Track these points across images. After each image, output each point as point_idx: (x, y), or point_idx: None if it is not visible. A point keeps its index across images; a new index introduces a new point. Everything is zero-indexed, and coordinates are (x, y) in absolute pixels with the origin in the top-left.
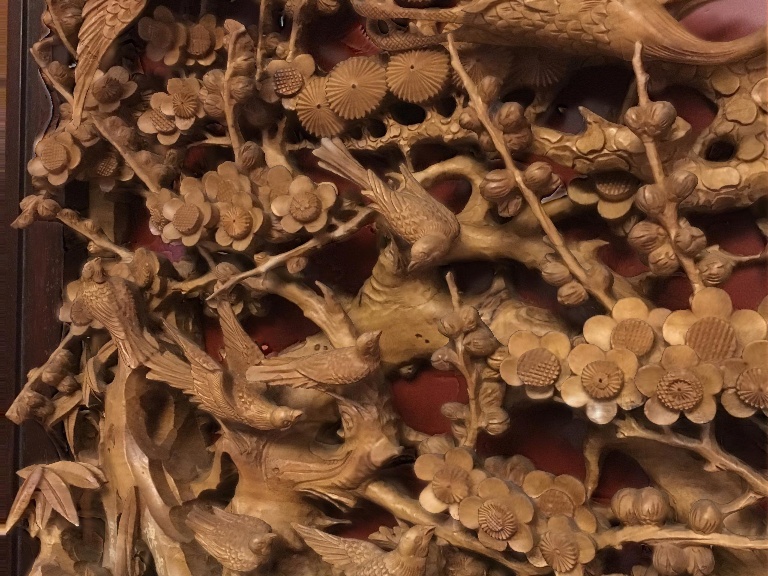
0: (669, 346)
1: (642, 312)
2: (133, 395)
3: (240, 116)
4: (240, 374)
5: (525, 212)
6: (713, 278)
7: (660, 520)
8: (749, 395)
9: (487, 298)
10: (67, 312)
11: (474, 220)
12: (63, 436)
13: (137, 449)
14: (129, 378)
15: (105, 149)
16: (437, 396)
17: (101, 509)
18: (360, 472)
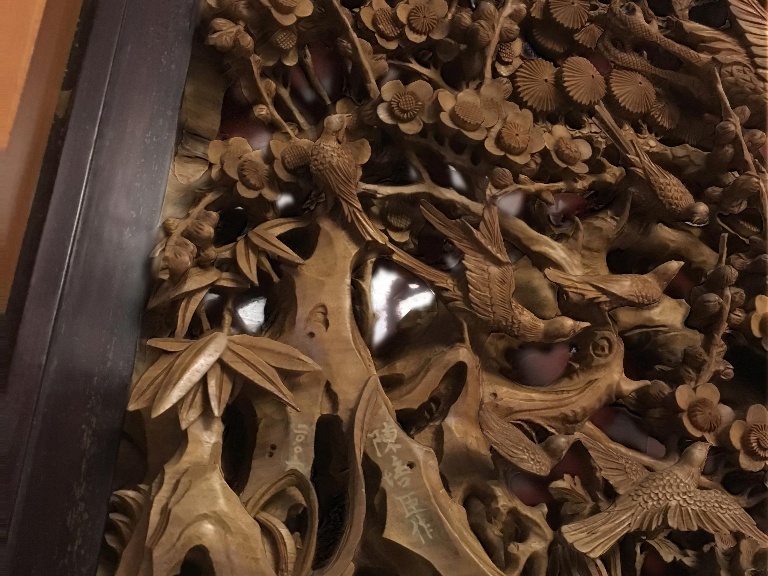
0: None
1: None
2: None
3: (455, 58)
4: None
5: (686, 226)
6: None
7: None
8: None
9: None
10: (233, 167)
11: None
12: (175, 319)
13: (360, 338)
14: (354, 256)
15: (299, 20)
16: None
17: (283, 408)
18: (599, 402)
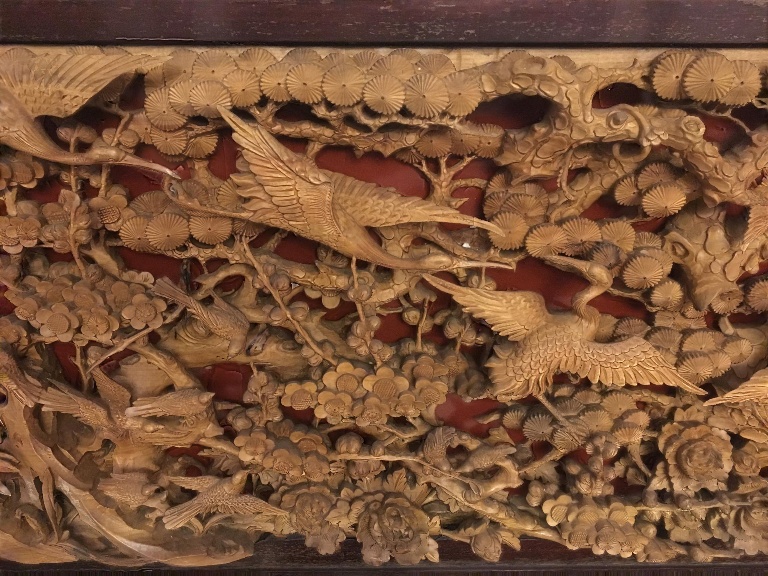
0: (368, 397)
1: (351, 369)
2: (29, 415)
3: None
4: (111, 400)
5: None
6: None
7: (358, 451)
8: (401, 413)
9: (258, 336)
10: None
11: (250, 303)
12: None
13: (41, 445)
14: (25, 408)
15: None
16: (229, 380)
17: (17, 475)
18: (197, 439)
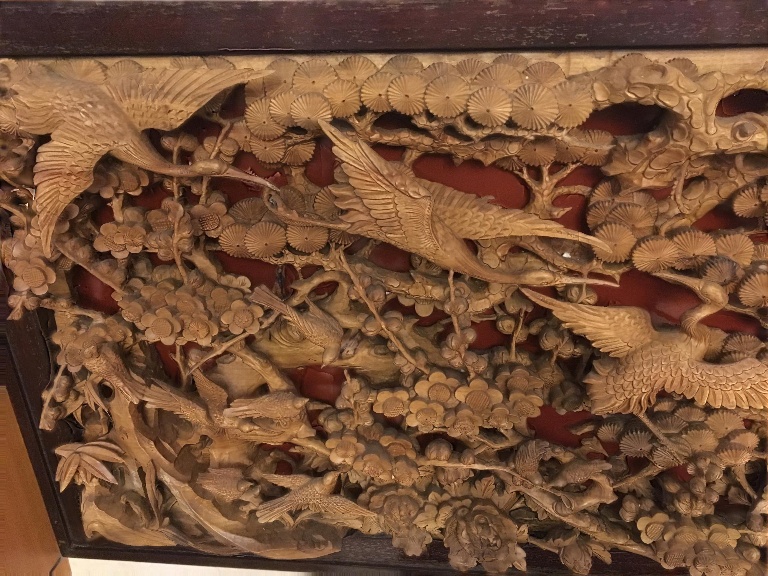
0: (460, 409)
1: (443, 379)
2: (134, 410)
3: None
4: (209, 399)
5: None
6: (479, 371)
7: None
8: (493, 425)
9: (350, 340)
10: (62, 359)
11: (344, 308)
12: (73, 419)
13: (145, 438)
14: (130, 403)
15: None
16: (320, 380)
17: (123, 464)
18: None
